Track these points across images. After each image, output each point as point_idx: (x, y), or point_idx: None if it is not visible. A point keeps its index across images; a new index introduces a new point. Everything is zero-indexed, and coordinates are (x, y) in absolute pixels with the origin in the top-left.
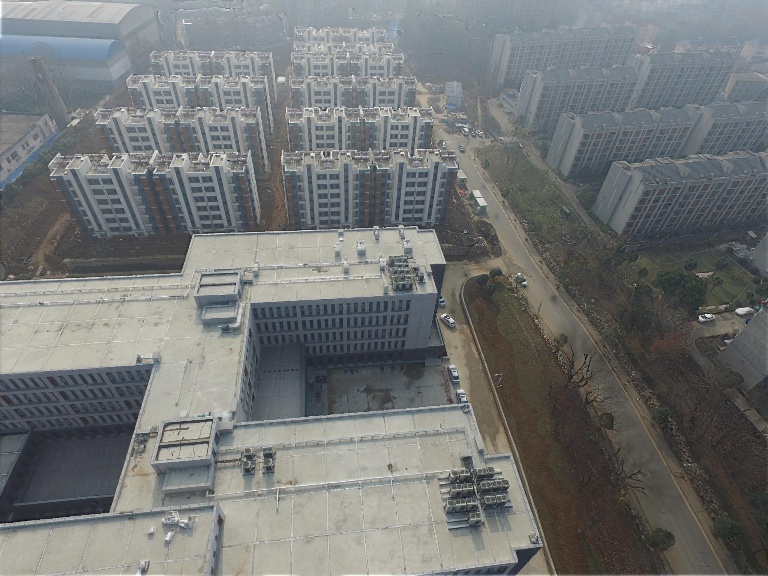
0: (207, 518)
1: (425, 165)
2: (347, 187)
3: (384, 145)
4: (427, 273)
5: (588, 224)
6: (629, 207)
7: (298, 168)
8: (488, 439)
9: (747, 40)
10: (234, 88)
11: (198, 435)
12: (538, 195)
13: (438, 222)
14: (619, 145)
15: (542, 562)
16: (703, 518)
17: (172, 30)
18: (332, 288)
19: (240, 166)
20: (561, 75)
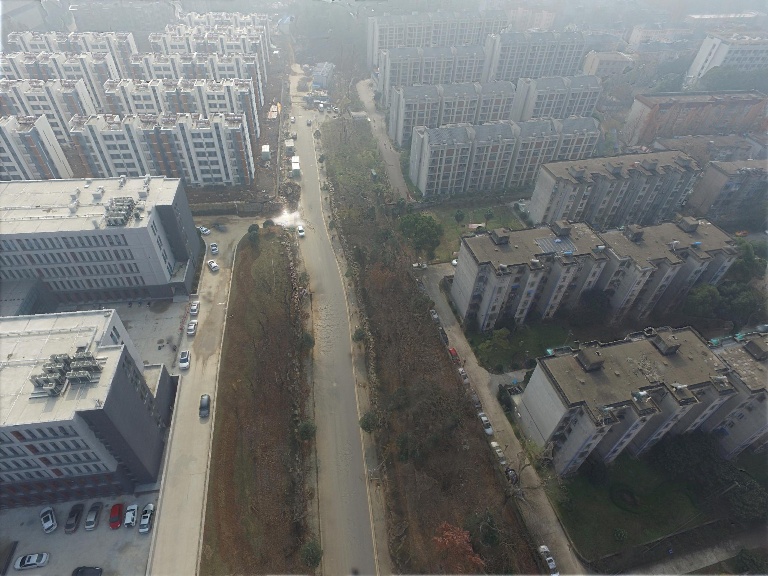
0: None
1: (210, 126)
2: (135, 147)
3: (205, 114)
4: (147, 212)
5: (400, 186)
6: (425, 168)
7: (83, 129)
8: (201, 359)
9: (634, 25)
10: (73, 64)
11: None
12: (358, 161)
13: (240, 182)
14: (446, 115)
15: (205, 454)
16: None
17: (66, 17)
18: (51, 224)
19: (30, 128)
20: (409, 53)
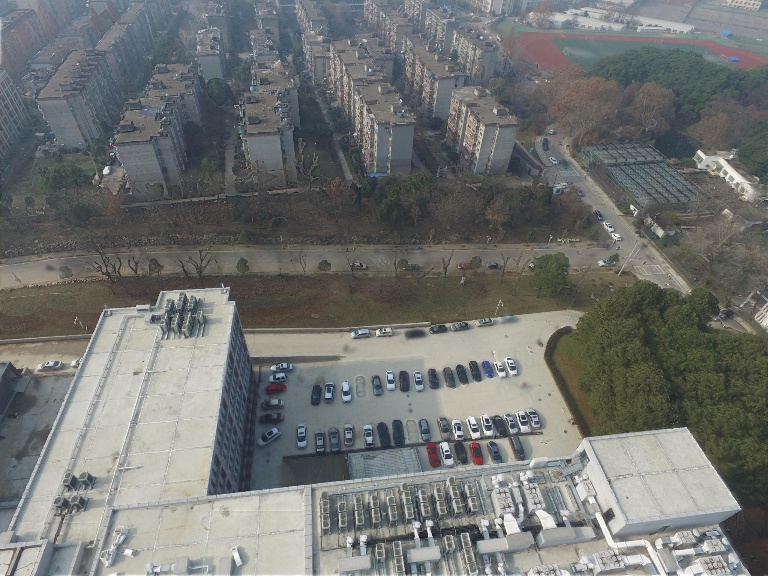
0: (124, 516)
1: None
2: None
3: None
4: None
5: None
6: None
7: None
8: None
9: None
10: None
11: (3, 567)
12: None
13: None
14: None
15: None
16: (237, 248)
17: None
18: None
19: None
20: None
